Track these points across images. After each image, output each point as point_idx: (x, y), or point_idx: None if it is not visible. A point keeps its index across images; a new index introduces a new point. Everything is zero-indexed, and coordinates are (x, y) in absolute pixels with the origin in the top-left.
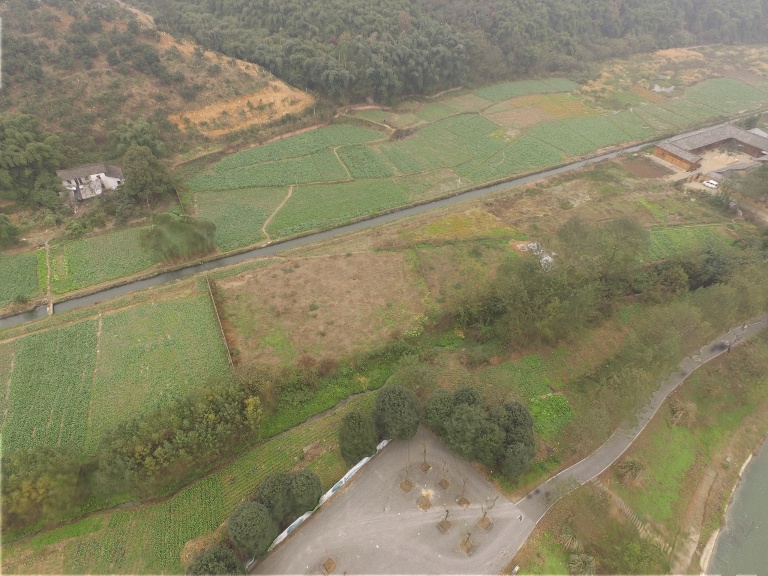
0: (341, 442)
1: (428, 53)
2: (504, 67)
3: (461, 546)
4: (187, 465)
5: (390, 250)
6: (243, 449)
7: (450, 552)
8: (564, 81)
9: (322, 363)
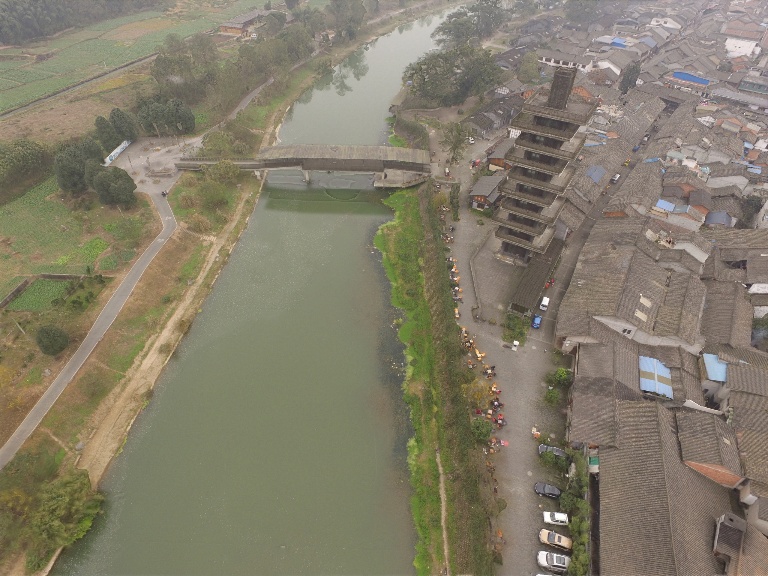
0: (101, 141)
1: (29, 0)
2: (100, 8)
3: (179, 152)
4: (21, 171)
5: (79, 100)
6: (49, 176)
7: (176, 154)
8: (152, 12)
9: (71, 139)
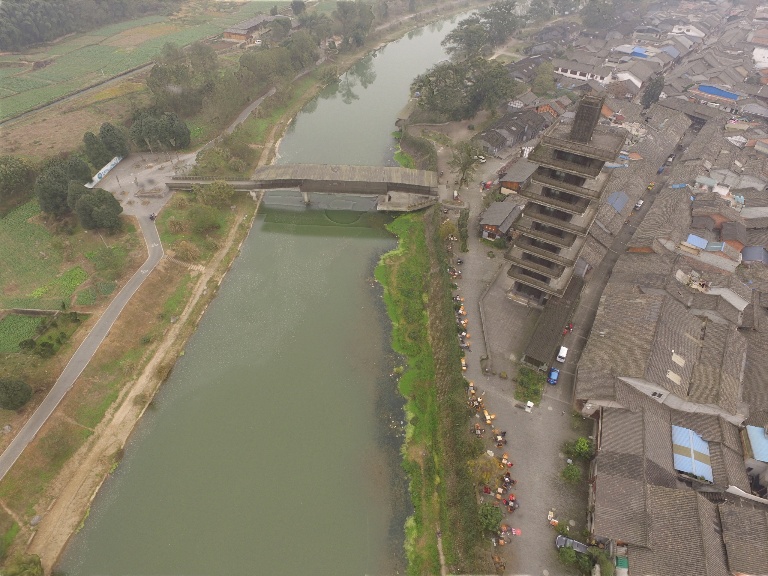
0: (90, 158)
1: (29, 5)
2: (103, 13)
3: (172, 169)
4: (3, 191)
5: (73, 111)
6: None
7: (168, 172)
8: (156, 17)
9: (60, 154)
